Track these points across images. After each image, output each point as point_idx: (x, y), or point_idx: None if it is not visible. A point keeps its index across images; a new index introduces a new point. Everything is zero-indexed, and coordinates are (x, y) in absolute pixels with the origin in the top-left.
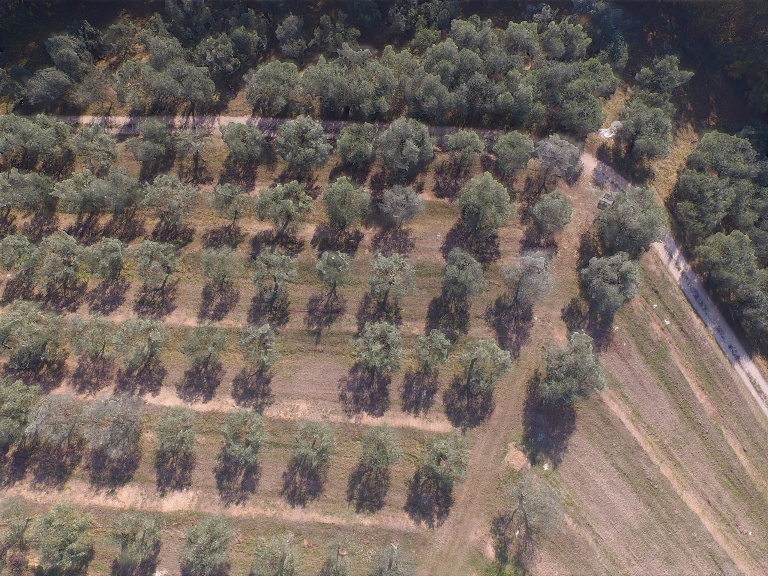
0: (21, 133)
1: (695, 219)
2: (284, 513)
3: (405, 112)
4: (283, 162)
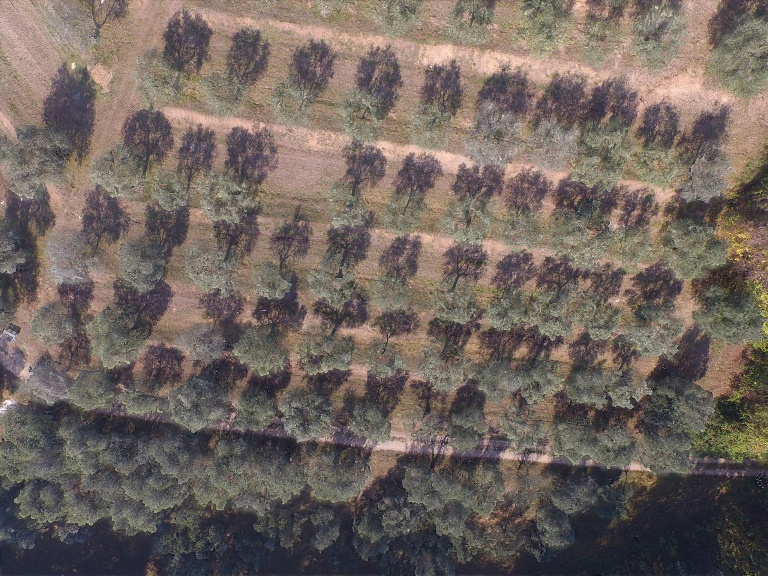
0: (598, 447)
1: None
2: (331, 36)
3: (213, 441)
4: (338, 398)
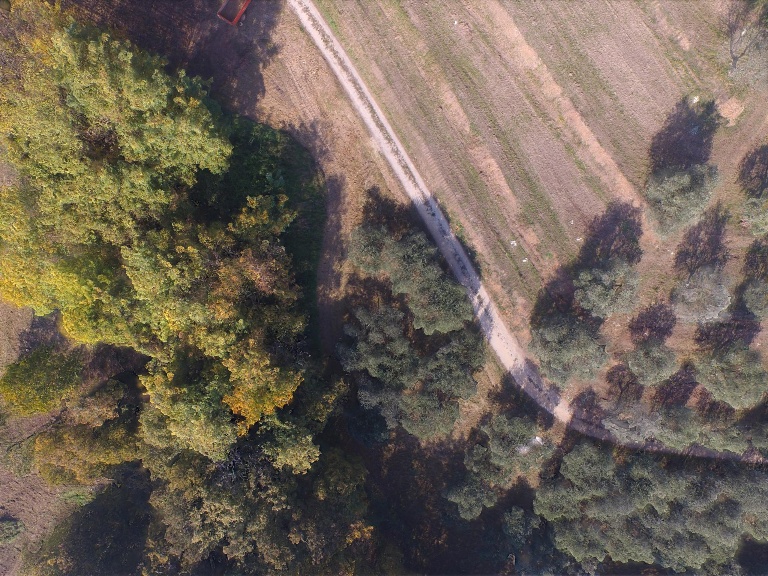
0: None
1: (469, 348)
2: None
3: None
4: None
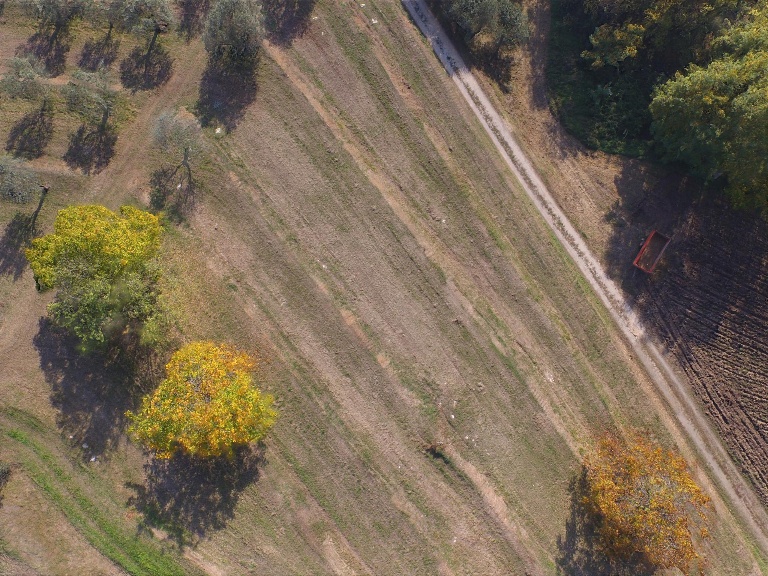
0: None
1: None
2: None
3: None
4: None
